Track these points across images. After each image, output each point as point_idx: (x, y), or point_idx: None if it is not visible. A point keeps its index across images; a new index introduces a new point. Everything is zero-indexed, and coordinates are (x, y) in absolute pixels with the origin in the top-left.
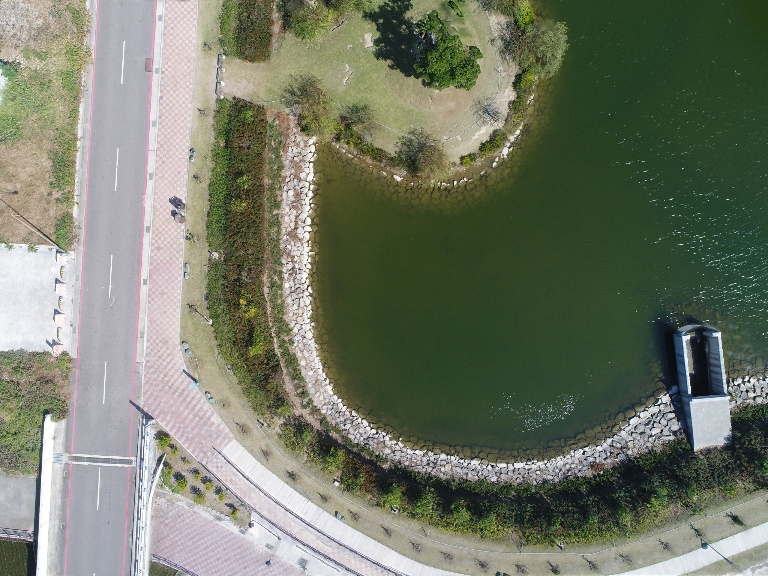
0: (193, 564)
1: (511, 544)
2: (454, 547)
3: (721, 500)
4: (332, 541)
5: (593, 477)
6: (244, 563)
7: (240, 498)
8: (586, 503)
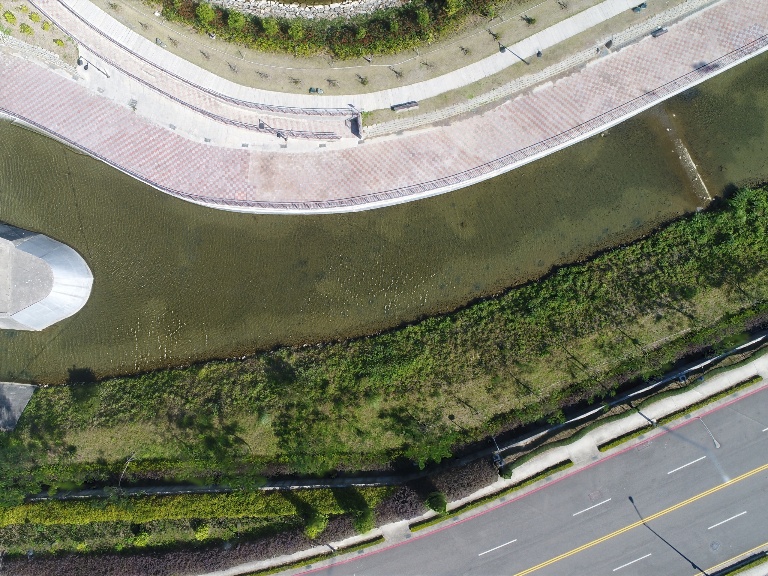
0: (30, 111)
1: (322, 61)
2: (269, 67)
3: (516, 5)
4: (154, 68)
5: (402, 7)
6: (78, 107)
7: (66, 32)
8: (392, 21)
